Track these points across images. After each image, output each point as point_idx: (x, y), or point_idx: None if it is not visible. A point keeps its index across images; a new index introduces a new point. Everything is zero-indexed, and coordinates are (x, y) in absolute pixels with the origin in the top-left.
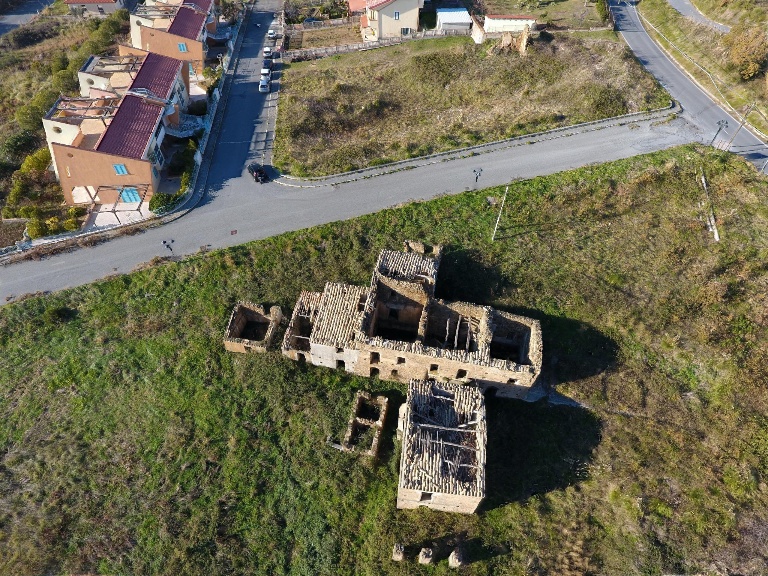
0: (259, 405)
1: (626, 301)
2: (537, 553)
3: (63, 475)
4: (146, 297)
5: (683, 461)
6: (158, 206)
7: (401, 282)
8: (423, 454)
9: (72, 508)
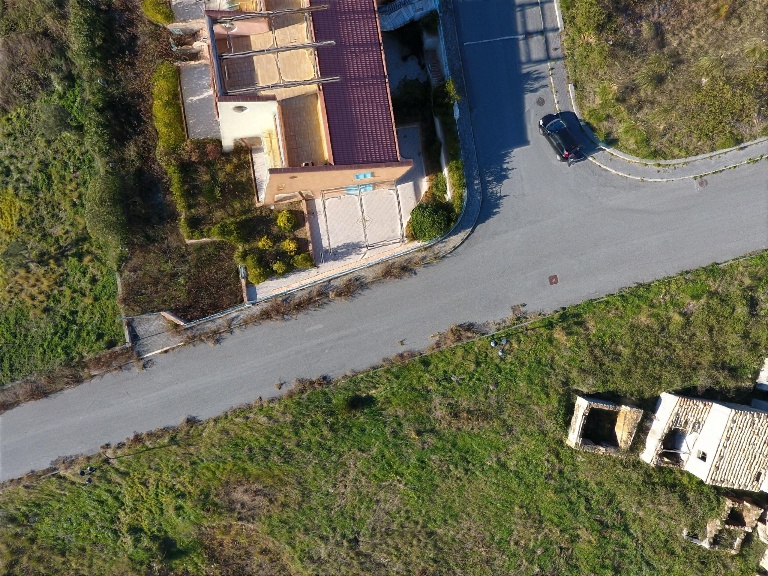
0: (609, 500)
1: None
2: None
3: (422, 558)
4: (455, 382)
5: None
6: (433, 236)
7: None
8: None
9: None
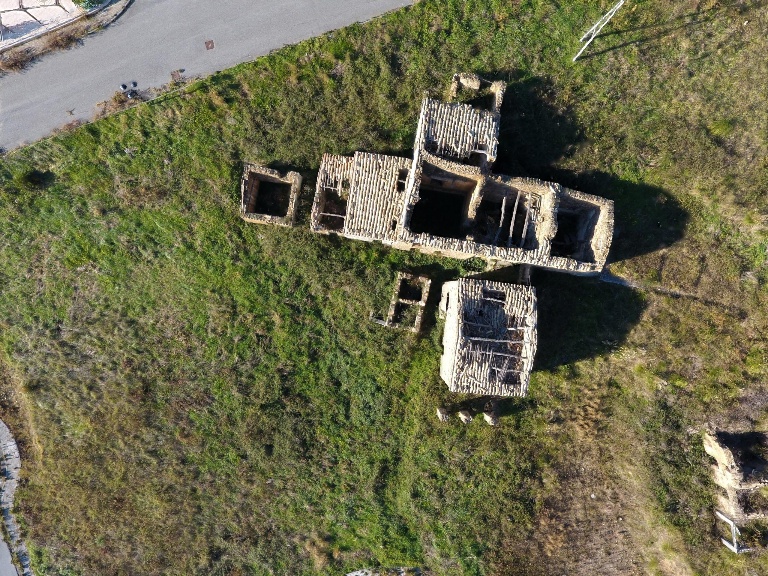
0: (295, 282)
1: (724, 161)
2: (559, 407)
3: (125, 348)
4: (128, 154)
5: (715, 342)
6: None
7: (453, 164)
8: (473, 364)
9: (146, 374)
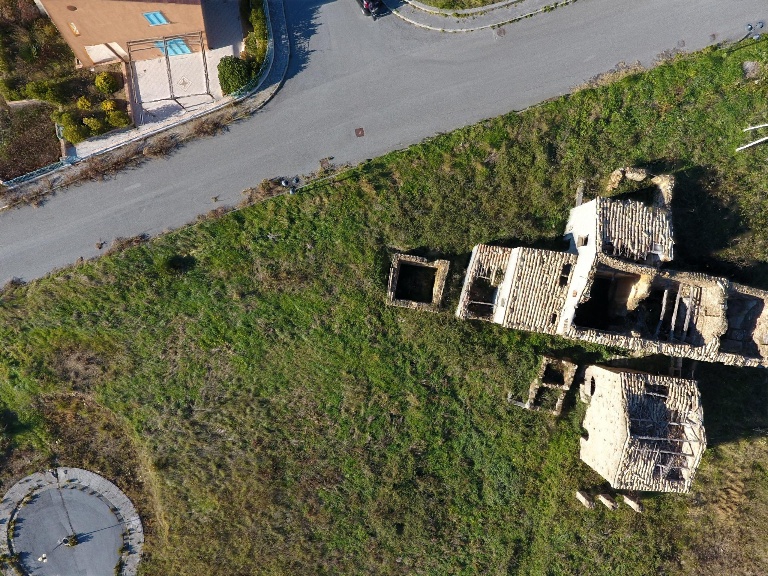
0: (433, 363)
1: None
2: (700, 490)
3: (256, 427)
4: (271, 240)
5: None
6: (236, 87)
7: (630, 266)
8: (638, 462)
9: (276, 452)
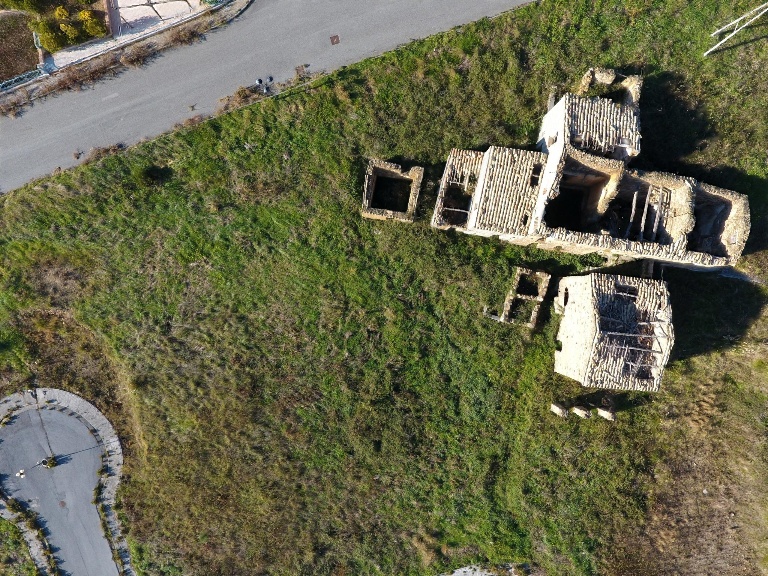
0: (410, 277)
1: None
2: (673, 403)
3: (234, 344)
4: (248, 150)
5: None
6: None
7: (597, 158)
8: (608, 359)
9: (255, 370)
